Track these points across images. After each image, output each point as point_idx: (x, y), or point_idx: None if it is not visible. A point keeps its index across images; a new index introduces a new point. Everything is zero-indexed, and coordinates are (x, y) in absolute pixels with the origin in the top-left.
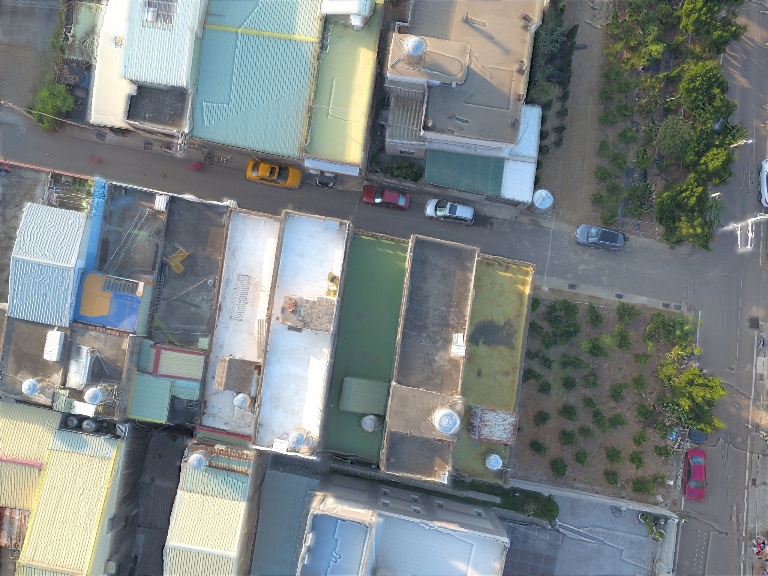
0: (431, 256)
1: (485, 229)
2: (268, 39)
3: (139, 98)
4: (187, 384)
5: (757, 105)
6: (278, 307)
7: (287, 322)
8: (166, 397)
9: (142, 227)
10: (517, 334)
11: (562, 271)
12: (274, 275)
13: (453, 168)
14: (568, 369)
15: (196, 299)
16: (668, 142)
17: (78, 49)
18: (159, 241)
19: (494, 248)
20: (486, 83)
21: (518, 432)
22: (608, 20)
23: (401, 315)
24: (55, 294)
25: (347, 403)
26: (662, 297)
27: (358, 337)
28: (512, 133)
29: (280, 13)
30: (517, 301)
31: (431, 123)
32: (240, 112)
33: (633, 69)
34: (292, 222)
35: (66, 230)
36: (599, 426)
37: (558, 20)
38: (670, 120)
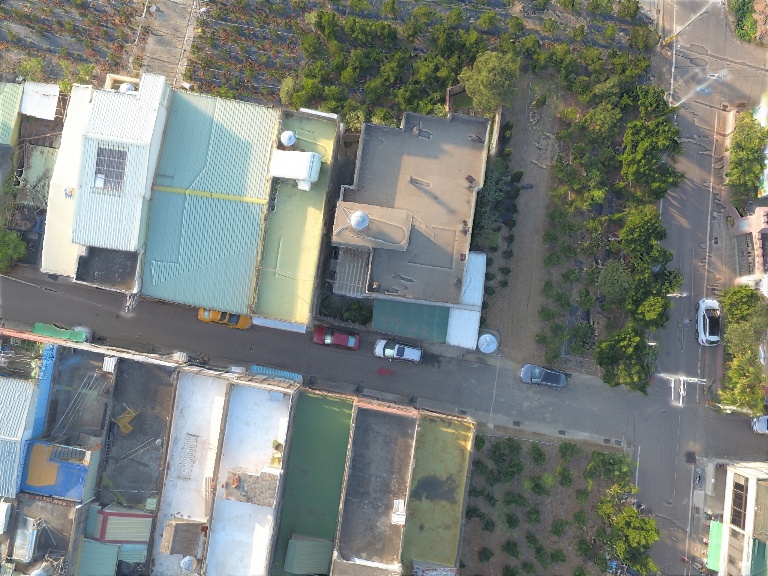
0: (373, 424)
1: (433, 367)
2: (216, 200)
3: (88, 257)
4: (135, 547)
5: (695, 244)
6: (223, 475)
7: (231, 497)
8: (113, 562)
9: (91, 386)
10: (459, 489)
11: (507, 408)
12: (219, 447)
13: (400, 316)
14: (512, 505)
15: (144, 457)
16: (608, 289)
17: (29, 193)
18: (108, 400)
19: (441, 386)
20: (430, 243)
21: (464, 567)
22: (553, 160)
23: (344, 482)
24: (2, 466)
25: (292, 566)
26: (603, 433)
27: (304, 494)
28: (455, 292)
29: (228, 173)
30: (459, 457)
31: (375, 285)
32: (188, 271)
33: (577, 210)
34: (237, 390)
35: (13, 402)
36: (541, 562)
37: (503, 167)
38: (610, 266)
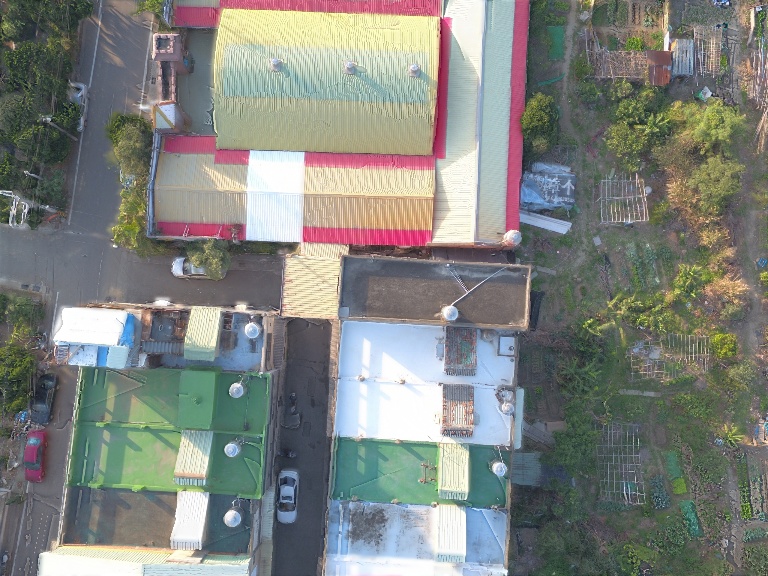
0: None
1: None
2: None
3: None
4: None
5: (130, 84)
6: None
7: None
8: None
9: None
10: None
11: None
12: None
13: None
14: None
15: None
16: None
17: None
18: None
19: None
20: None
21: None
22: None
23: None
24: None
25: None
26: (21, 278)
27: None
28: None
29: None
30: None
31: None
32: None
33: (2, 49)
34: None
35: None
36: None
37: None
38: None
